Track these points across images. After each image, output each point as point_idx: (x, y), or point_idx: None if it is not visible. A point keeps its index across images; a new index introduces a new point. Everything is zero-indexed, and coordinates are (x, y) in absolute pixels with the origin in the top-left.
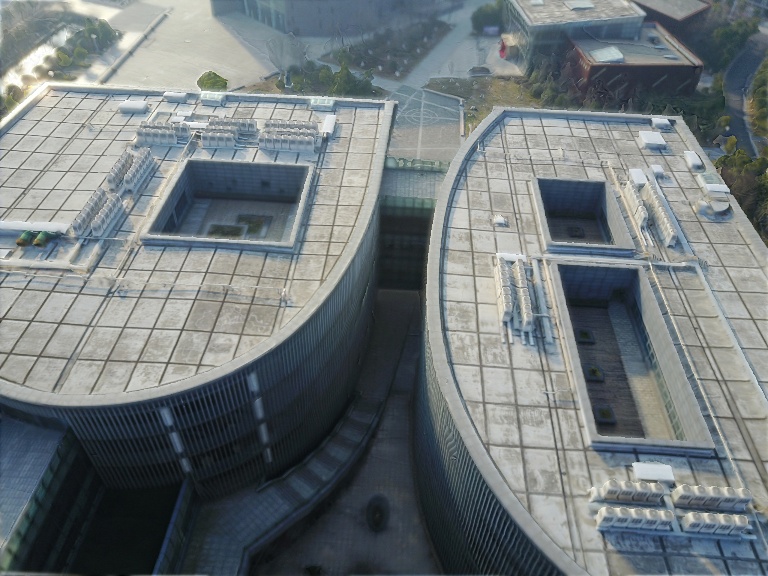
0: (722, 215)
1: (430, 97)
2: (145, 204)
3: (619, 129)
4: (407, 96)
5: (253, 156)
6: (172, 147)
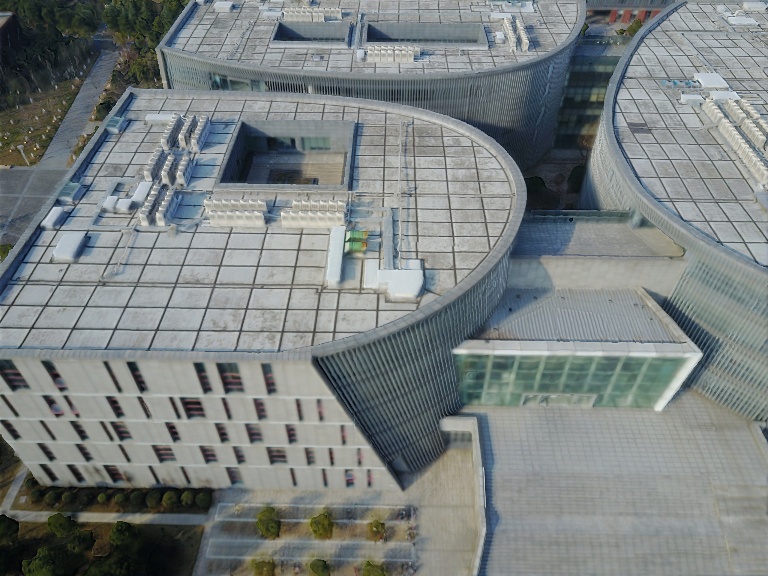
0: (313, 2)
1: None
2: (290, 201)
3: (201, 15)
4: None
5: (213, 154)
6: (181, 204)
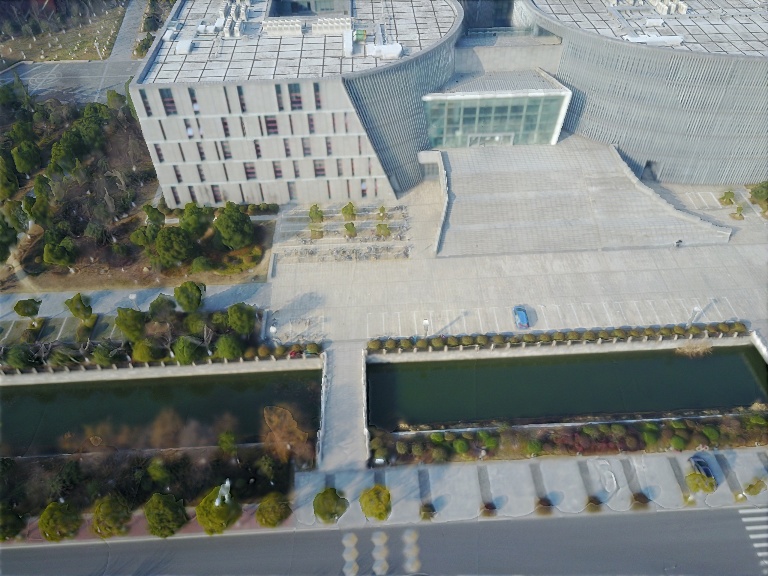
0: None
1: (8, 76)
2: None
3: None
4: (0, 85)
5: (259, 6)
6: None
